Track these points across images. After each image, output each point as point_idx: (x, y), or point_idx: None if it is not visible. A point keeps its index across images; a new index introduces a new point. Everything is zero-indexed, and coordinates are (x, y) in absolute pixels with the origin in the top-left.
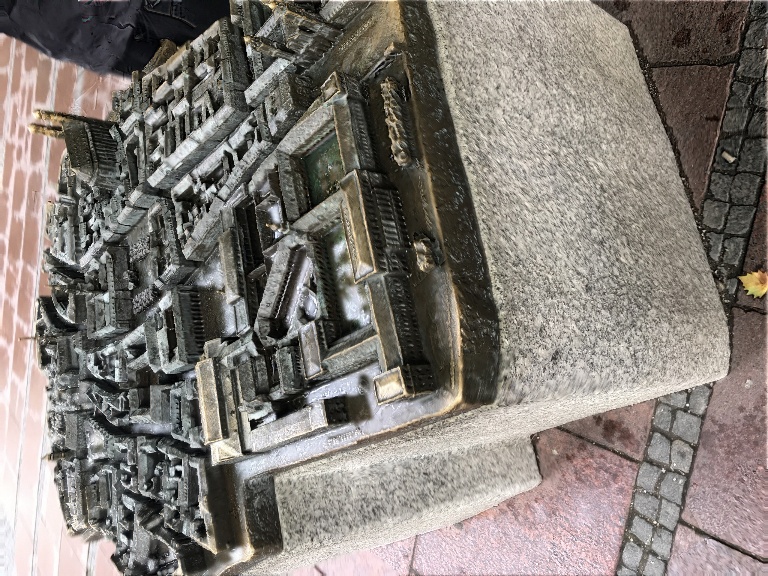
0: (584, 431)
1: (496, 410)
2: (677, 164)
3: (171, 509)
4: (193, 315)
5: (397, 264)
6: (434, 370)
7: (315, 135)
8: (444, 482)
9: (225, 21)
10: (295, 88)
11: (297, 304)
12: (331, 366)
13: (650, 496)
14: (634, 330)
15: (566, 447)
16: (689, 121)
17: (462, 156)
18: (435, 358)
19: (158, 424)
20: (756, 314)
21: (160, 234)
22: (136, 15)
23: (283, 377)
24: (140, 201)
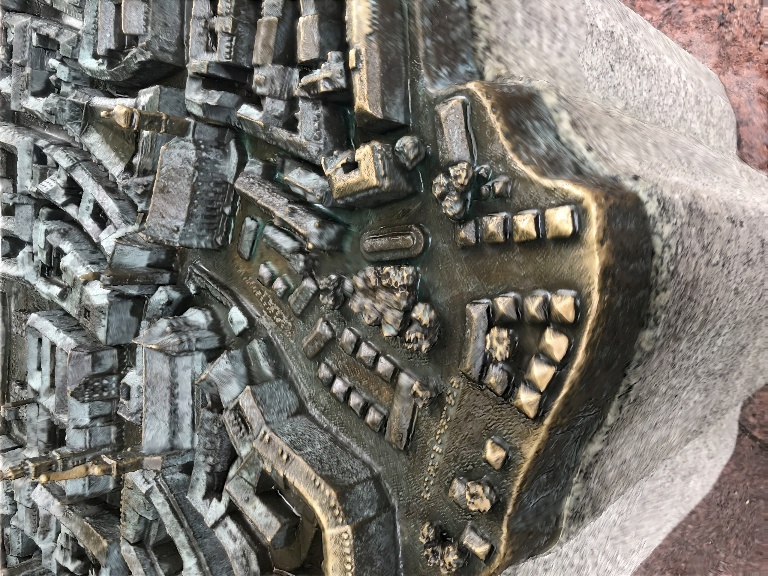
0: None
1: None
2: None
3: None
4: None
5: None
6: None
7: None
8: None
9: None
10: None
11: None
12: None
13: None
14: None
15: None
16: None
17: None
18: None
19: (48, 132)
20: None
21: None
22: None
23: None
24: None
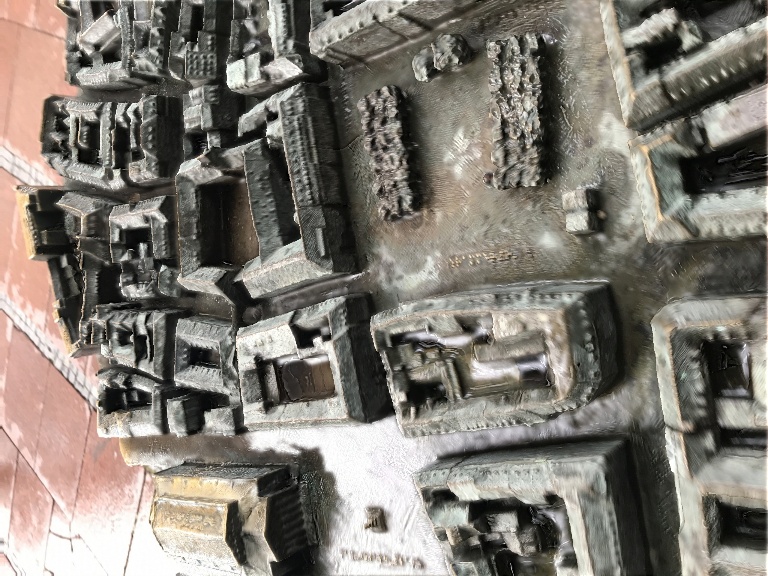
0: None
1: None
2: None
3: None
4: None
5: None
6: None
7: None
8: None
9: None
10: None
11: None
12: None
13: None
14: None
15: None
16: None
17: None
18: None
19: None
20: None
21: None
22: None
23: None
24: None
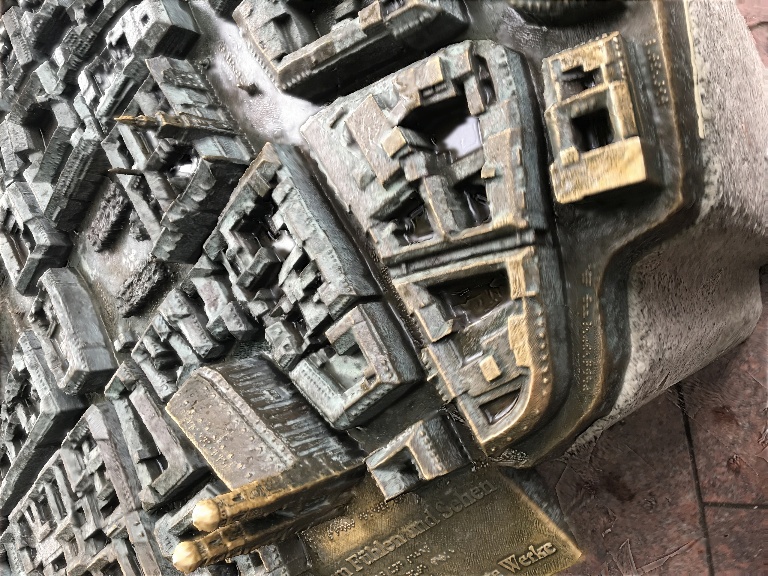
0: None
1: None
2: None
3: None
4: None
5: None
6: None
7: None
8: None
9: None
10: None
11: None
12: None
13: None
14: None
15: None
16: None
17: None
18: None
19: None
20: None
21: None
22: None
23: None
24: None
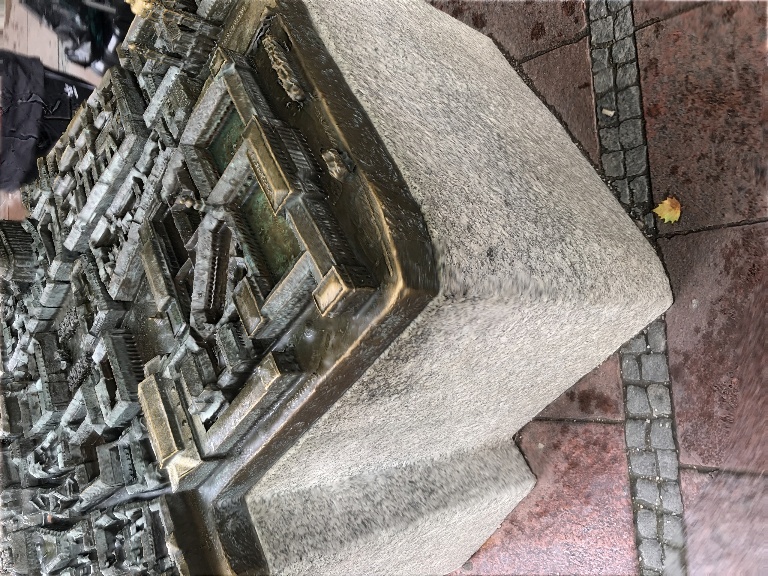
0: (562, 412)
1: (446, 314)
2: (567, 133)
3: (138, 570)
4: (130, 356)
5: (312, 187)
6: (371, 270)
7: (213, 116)
8: (433, 489)
9: (115, 69)
10: (188, 87)
11: (227, 278)
12: (271, 312)
13: (644, 452)
14: (565, 244)
15: (550, 435)
16: (566, 95)
17: (353, 91)
18: (369, 259)
19: (113, 496)
20: (679, 237)
21: (84, 292)
22: (37, 127)
23: (227, 354)
24: (60, 273)
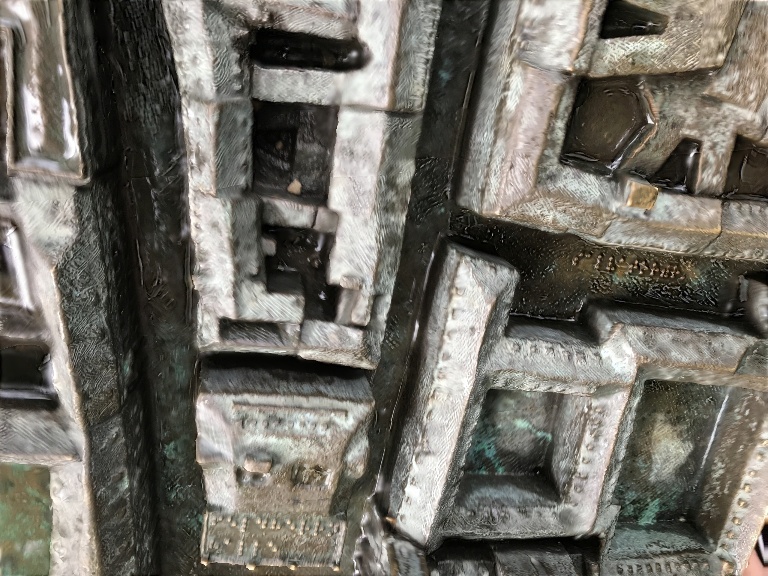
0: None
1: None
2: None
3: None
4: None
5: None
6: None
7: None
8: None
9: None
10: None
11: None
12: None
13: None
14: None
15: None
16: None
17: None
18: None
19: None
20: None
21: None
22: None
23: None
24: None
